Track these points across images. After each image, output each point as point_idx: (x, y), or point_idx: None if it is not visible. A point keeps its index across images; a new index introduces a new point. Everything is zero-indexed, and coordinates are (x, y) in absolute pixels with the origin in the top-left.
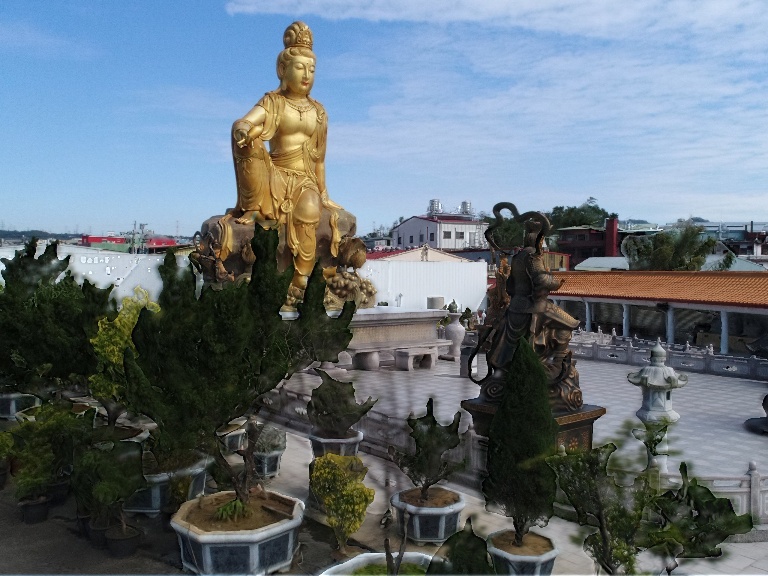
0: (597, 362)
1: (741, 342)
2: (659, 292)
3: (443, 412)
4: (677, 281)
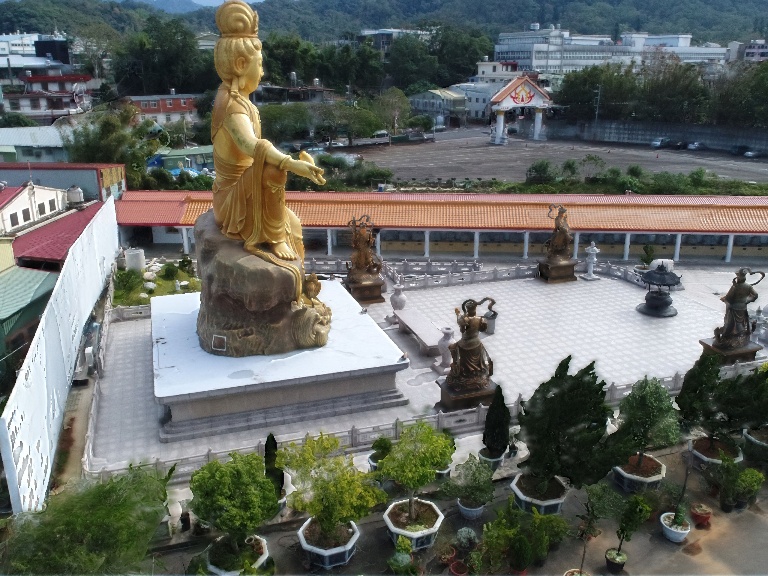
0: (436, 289)
1: (420, 245)
2: (369, 219)
3: (607, 361)
4: (372, 209)
